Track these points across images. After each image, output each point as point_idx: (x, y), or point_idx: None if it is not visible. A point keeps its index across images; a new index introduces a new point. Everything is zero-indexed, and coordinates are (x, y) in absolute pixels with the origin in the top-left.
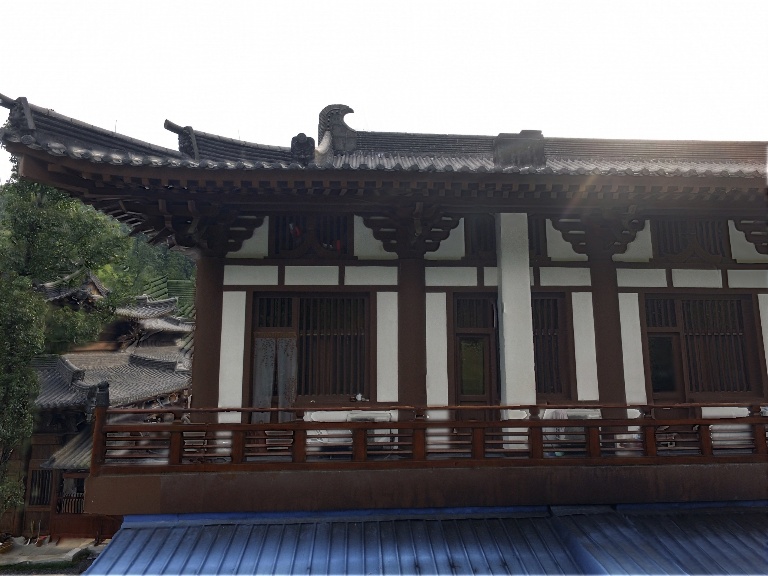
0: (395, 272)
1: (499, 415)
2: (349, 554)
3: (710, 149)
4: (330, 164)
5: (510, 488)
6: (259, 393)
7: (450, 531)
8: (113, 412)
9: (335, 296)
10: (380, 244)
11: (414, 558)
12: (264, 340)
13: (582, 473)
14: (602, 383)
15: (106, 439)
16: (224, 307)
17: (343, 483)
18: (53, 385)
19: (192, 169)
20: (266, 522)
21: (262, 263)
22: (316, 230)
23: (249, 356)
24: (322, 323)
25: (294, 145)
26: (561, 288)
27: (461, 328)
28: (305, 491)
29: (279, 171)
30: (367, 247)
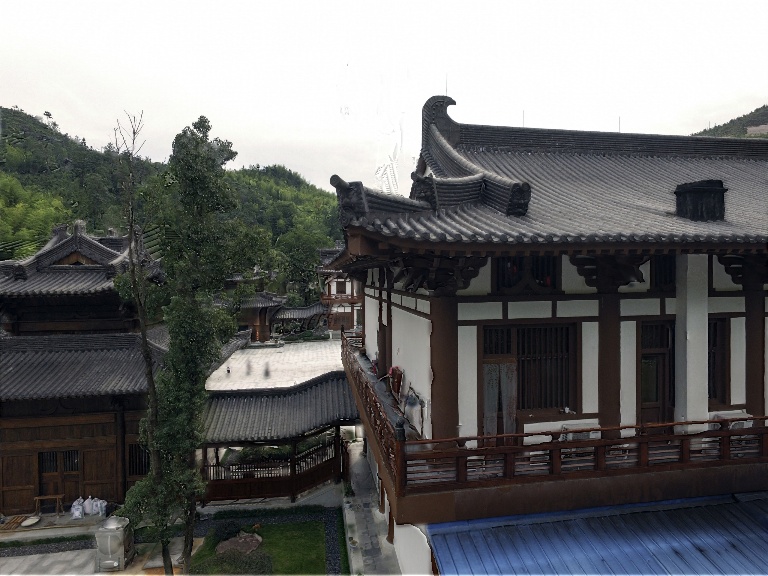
0: (597, 305)
1: (673, 419)
2: (620, 545)
3: (767, 147)
4: (606, 237)
5: (708, 483)
6: (487, 410)
7: (675, 520)
8: (410, 444)
9: (546, 326)
10: (583, 279)
11: (670, 546)
12: (489, 366)
13: (757, 469)
14: (748, 390)
15: (407, 466)
16: (459, 340)
17: (590, 488)
18: (143, 365)
19: (496, 243)
20: (536, 521)
21: (489, 300)
22: (531, 268)
23: (482, 381)
24: (535, 349)
25: (515, 191)
26: (723, 314)
27: (643, 349)
28: (563, 496)
29: (566, 244)
30: (572, 282)
